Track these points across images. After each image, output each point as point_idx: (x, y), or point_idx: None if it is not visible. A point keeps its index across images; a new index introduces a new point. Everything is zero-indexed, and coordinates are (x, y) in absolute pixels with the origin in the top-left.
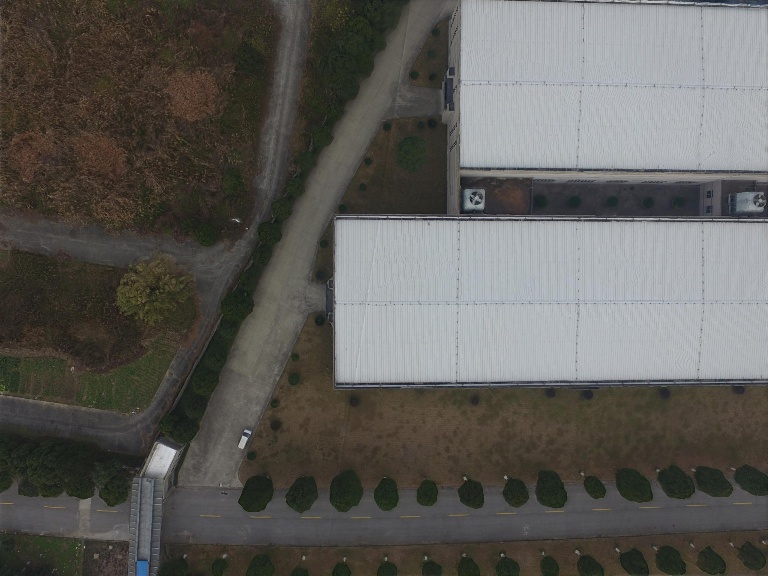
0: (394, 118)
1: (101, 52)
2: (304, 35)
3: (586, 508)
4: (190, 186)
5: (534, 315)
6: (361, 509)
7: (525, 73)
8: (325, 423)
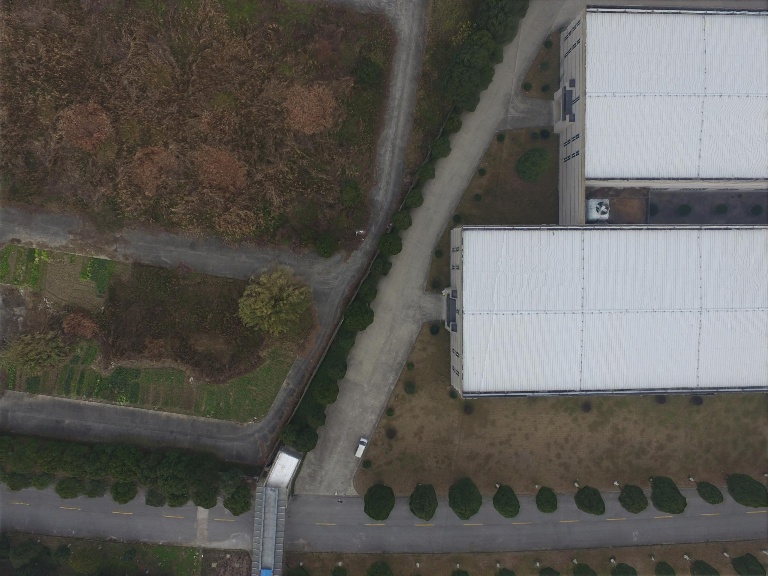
0: (507, 129)
1: (224, 67)
2: (419, 48)
3: (694, 513)
4: (308, 198)
5: (657, 323)
6: (473, 516)
7: (649, 84)
8: (439, 431)
